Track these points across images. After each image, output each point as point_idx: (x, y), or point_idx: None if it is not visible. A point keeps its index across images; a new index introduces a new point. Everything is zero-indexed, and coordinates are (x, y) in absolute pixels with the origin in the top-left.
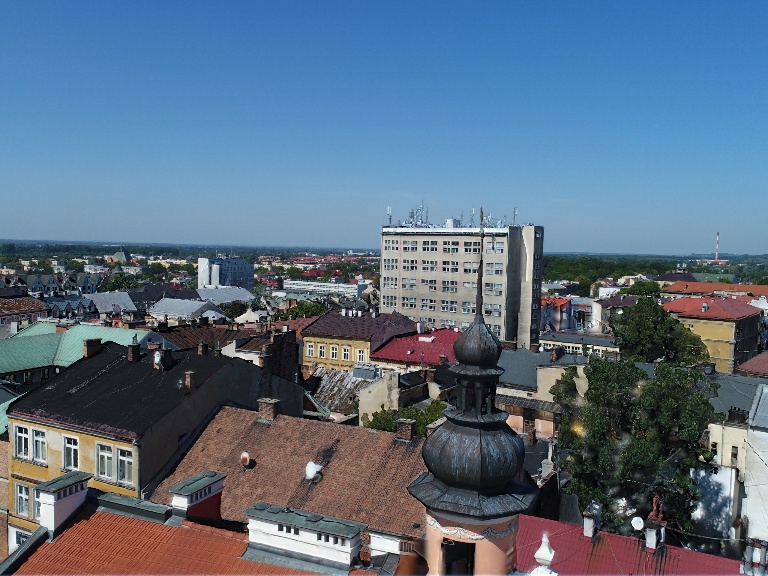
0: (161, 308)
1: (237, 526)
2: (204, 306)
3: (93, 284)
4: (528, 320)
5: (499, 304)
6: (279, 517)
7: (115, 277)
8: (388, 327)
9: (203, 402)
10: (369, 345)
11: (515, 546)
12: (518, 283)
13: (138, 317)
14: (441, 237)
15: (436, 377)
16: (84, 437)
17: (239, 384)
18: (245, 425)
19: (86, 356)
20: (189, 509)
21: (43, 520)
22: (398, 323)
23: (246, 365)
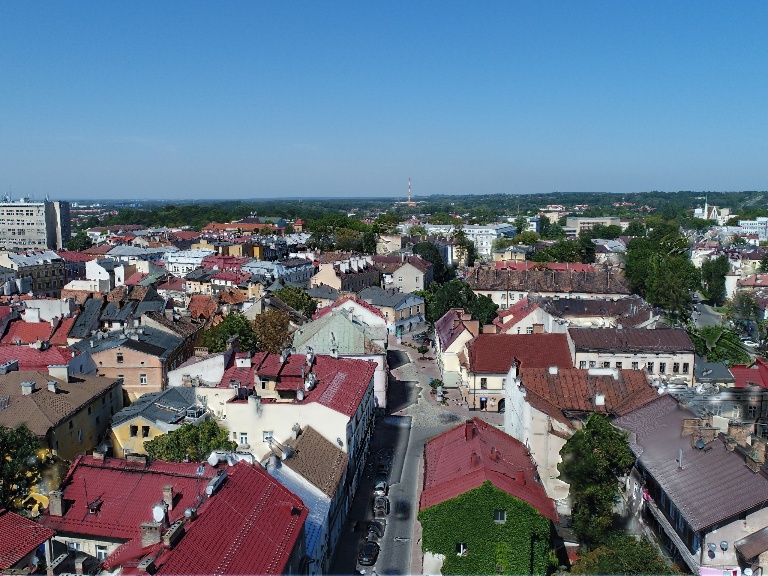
0: None
1: None
2: None
3: None
4: (61, 246)
5: (44, 239)
6: None
7: None
8: None
9: None
10: None
11: None
12: (55, 229)
13: None
14: (15, 208)
15: None
16: None
17: None
18: None
19: None
20: None
21: None
22: None
23: None
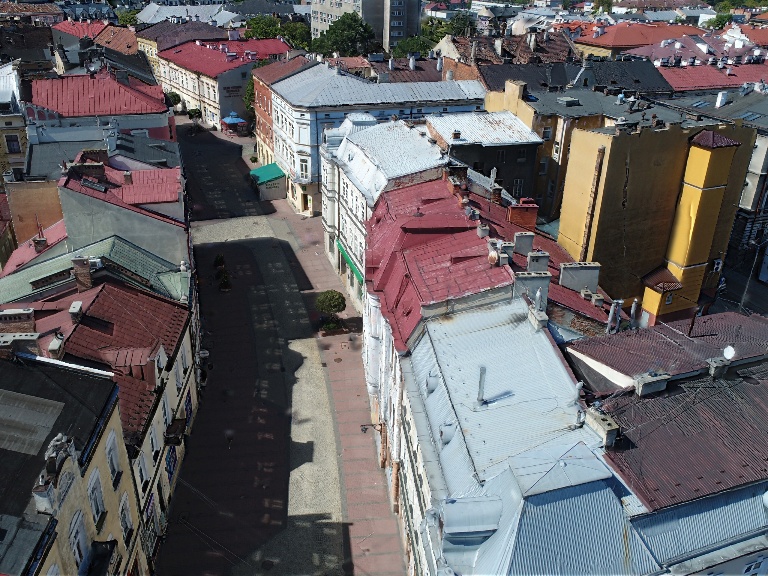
0: None
1: None
2: (235, 18)
3: None
4: (387, 37)
5: None
6: None
7: None
8: (182, 32)
9: None
10: (156, 45)
11: None
12: None
13: None
14: None
15: (12, 55)
16: None
17: None
18: None
19: None
20: None
21: None
22: (198, 29)
23: None
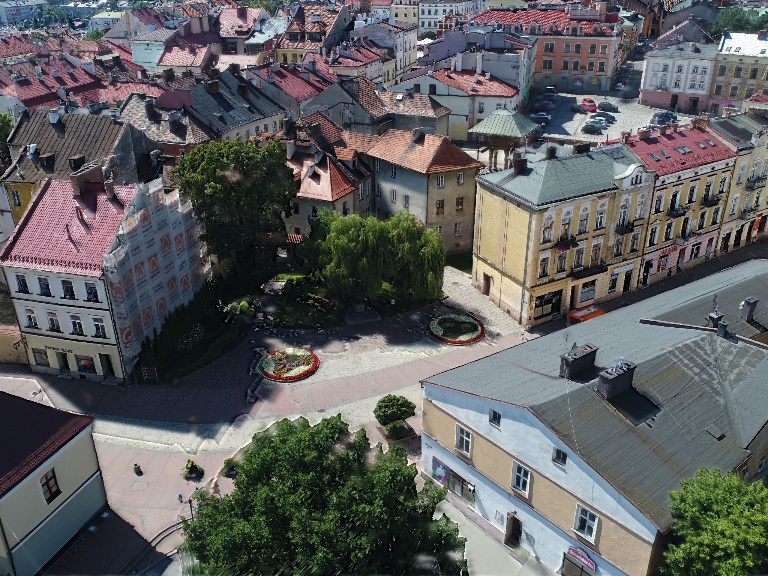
0: None
1: None
2: None
3: None
4: None
5: None
6: None
7: None
8: None
9: (687, 15)
10: None
11: (601, 7)
12: None
13: None
14: None
15: None
16: None
17: None
18: None
19: None
20: None
21: None
22: None
23: None
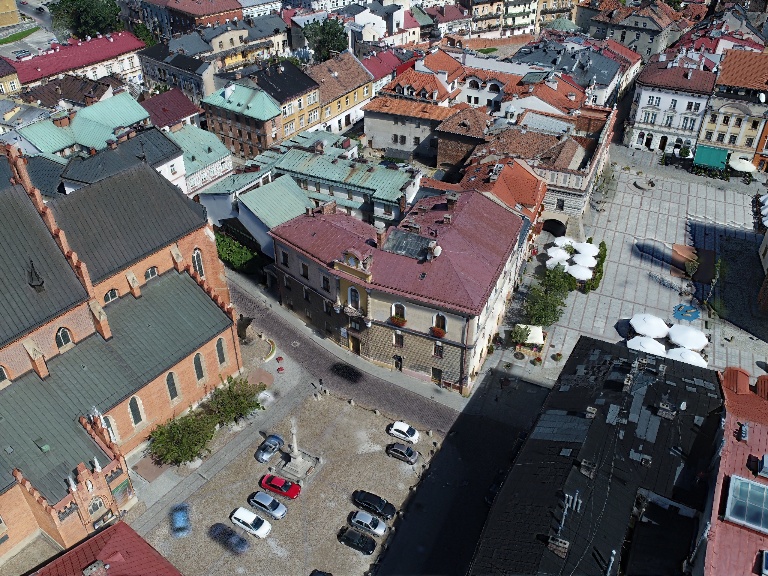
0: None
1: None
2: None
3: None
4: None
5: None
6: None
7: None
8: None
9: None
10: (17, 76)
11: None
12: None
13: None
14: None
15: None
16: None
17: None
18: None
19: None
20: None
21: None
22: None
23: None
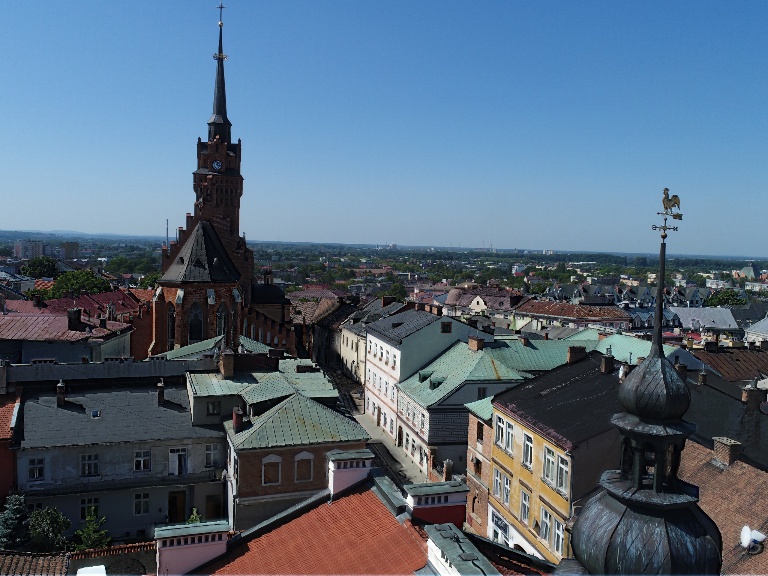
0: (761, 328)
1: (492, 549)
2: None
3: (702, 298)
4: None
5: None
6: (442, 542)
7: (725, 292)
8: None
9: None
10: None
11: None
12: None
13: (738, 336)
14: None
15: None
16: (537, 437)
17: (708, 416)
18: (696, 463)
19: (569, 362)
20: (415, 510)
21: (330, 483)
22: None
23: (720, 395)
